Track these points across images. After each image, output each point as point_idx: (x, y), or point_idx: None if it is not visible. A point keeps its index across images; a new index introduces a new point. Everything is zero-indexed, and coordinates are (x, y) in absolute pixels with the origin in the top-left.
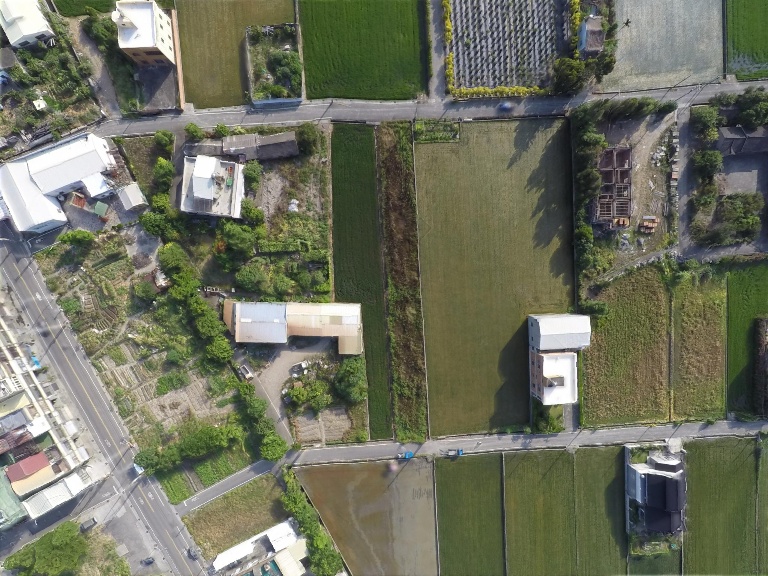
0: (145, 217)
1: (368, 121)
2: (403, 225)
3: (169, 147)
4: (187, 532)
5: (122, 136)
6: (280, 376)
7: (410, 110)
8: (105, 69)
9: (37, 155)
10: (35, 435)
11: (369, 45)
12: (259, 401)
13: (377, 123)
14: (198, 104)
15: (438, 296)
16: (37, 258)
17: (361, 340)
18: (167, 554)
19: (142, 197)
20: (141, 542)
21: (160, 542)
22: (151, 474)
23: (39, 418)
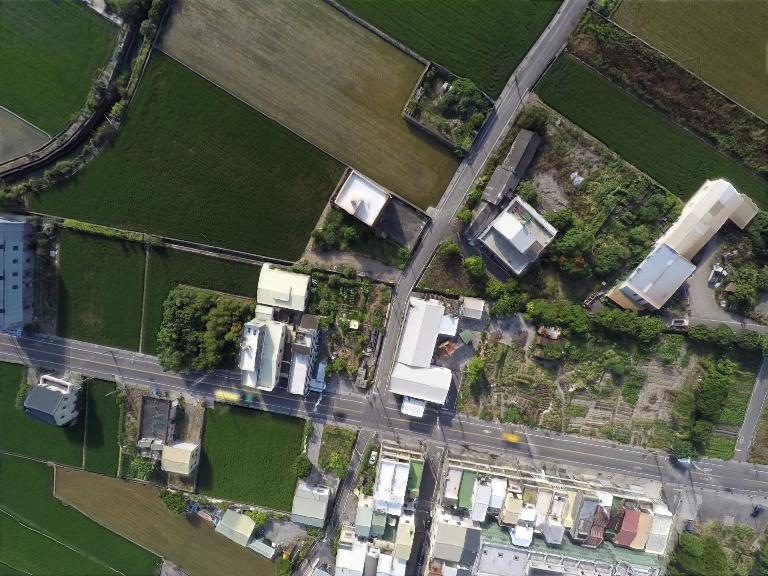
0: (501, 307)
1: (556, 53)
2: (674, 85)
3: (457, 249)
4: (762, 466)
5: (416, 282)
6: (706, 298)
7: (577, 1)
8: (358, 257)
9: (399, 351)
10: (610, 505)
11: (490, 4)
12: (720, 328)
13: (564, 45)
14: (433, 202)
15: (766, 96)
16: (459, 411)
17: (750, 200)
18: (764, 493)
19: (479, 299)
20: (736, 503)
21: (750, 490)
22: (697, 455)
23: (598, 493)
